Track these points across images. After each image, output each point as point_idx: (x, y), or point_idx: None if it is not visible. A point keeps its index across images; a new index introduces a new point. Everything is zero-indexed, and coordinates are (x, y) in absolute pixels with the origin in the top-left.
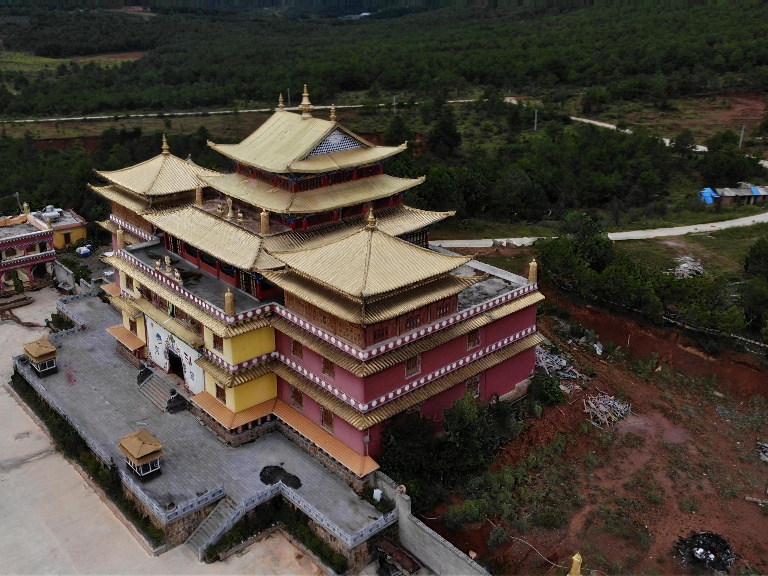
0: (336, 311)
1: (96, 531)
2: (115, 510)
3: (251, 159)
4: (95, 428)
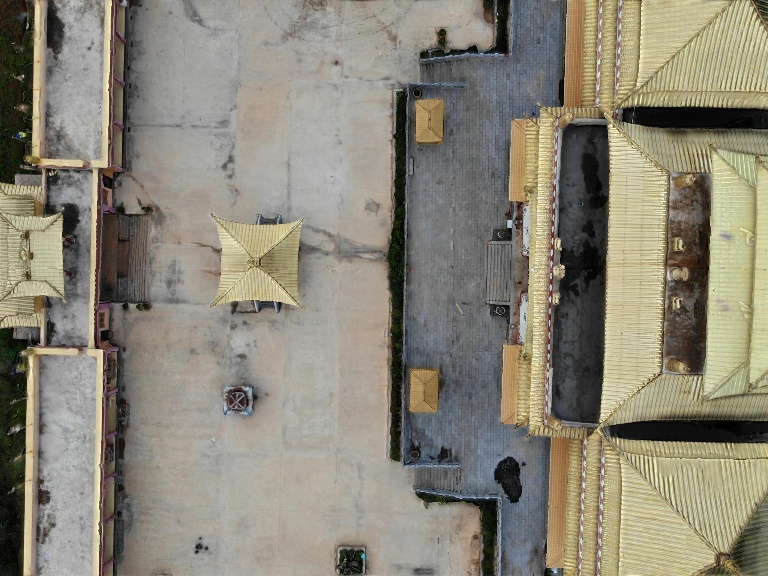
0: (604, 575)
1: (367, 397)
2: (389, 387)
3: (763, 263)
4: (420, 284)
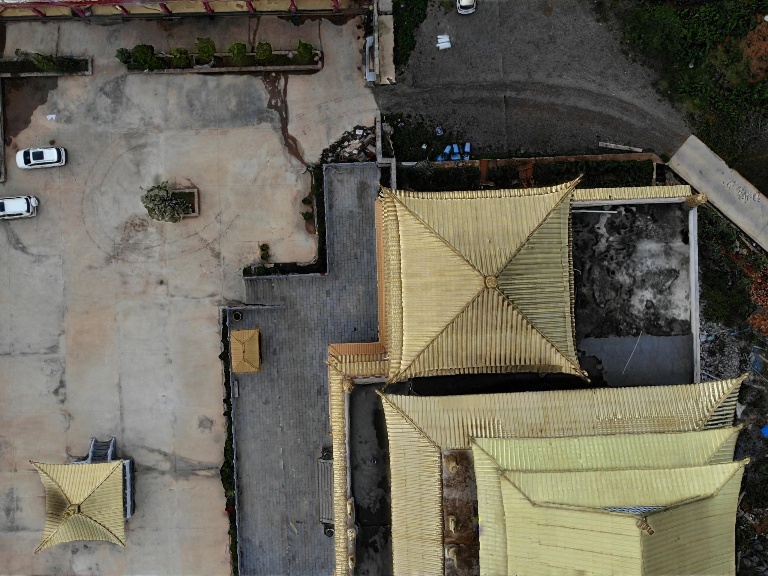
0: None
1: None
2: None
3: (514, 570)
4: (253, 506)
